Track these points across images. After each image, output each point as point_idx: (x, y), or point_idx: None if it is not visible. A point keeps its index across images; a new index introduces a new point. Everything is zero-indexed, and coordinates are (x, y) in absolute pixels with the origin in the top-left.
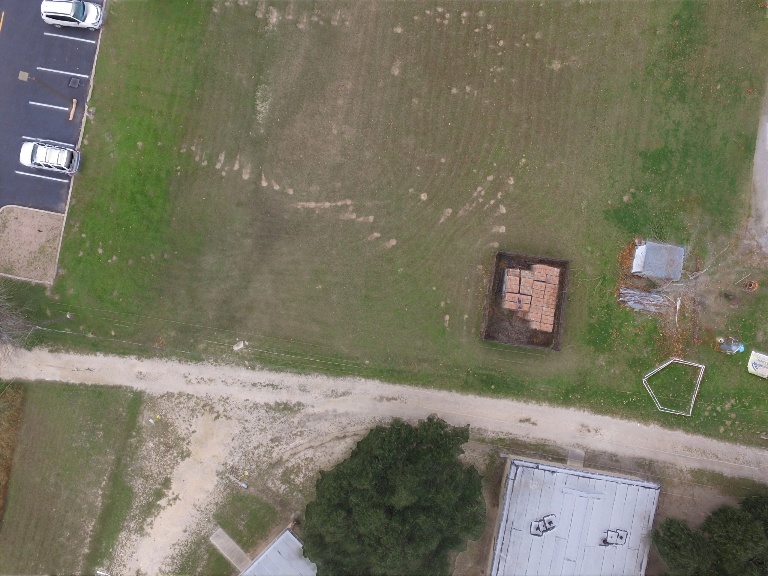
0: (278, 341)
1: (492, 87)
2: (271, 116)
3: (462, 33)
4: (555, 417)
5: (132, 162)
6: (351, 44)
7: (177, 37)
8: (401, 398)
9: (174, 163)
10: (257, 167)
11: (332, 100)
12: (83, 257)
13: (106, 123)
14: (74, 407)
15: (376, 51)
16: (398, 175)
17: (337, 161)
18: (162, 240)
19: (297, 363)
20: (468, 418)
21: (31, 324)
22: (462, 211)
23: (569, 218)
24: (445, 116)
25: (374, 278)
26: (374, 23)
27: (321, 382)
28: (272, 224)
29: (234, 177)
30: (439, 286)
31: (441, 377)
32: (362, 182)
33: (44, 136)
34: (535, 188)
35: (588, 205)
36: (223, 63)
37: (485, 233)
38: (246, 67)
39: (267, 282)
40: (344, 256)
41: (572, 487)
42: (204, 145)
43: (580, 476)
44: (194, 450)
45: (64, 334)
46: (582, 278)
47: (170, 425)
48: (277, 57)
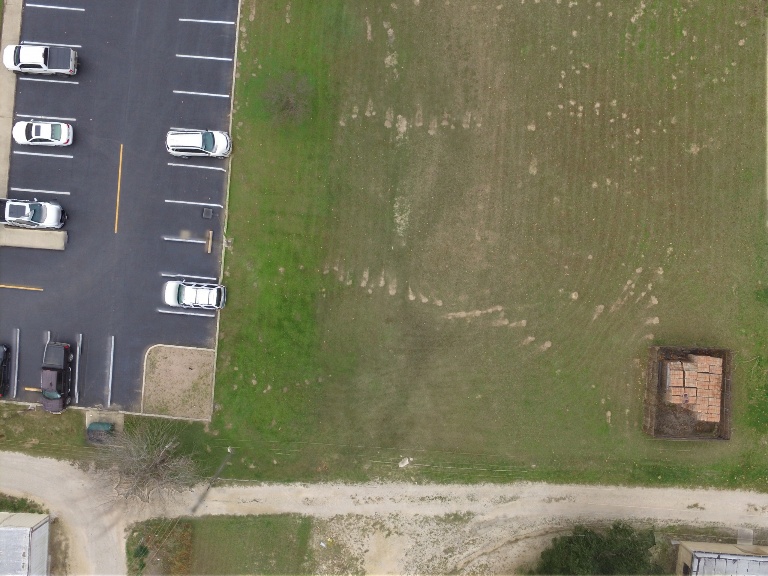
0: (442, 454)
1: (633, 177)
2: (412, 228)
3: (598, 125)
4: (722, 499)
5: (276, 289)
6: (486, 147)
7: (307, 156)
8: (569, 497)
9: (318, 285)
10: (403, 281)
11: (472, 206)
12: (238, 390)
13: (246, 252)
14: (244, 539)
15: (512, 151)
16: (547, 276)
17: (484, 268)
18: (315, 364)
19: (464, 474)
20: (637, 510)
21: (199, 467)
22: (614, 306)
23: (721, 302)
24: (589, 212)
25: (533, 382)
26: (507, 123)
27: (488, 490)
28: (424, 338)
29: (381, 294)
30: (598, 383)
31: (607, 473)
32: (511, 287)
33: (184, 272)
34: (685, 276)
35: (739, 287)
36: (357, 179)
37: (639, 326)
38: (381, 180)
39: (425, 396)
40: (501, 363)
41: (754, 573)
42: (347, 264)
43: (761, 561)
44: (368, 569)
45: (226, 468)
46: (739, 361)
47: (342, 547)
48: (412, 167)
